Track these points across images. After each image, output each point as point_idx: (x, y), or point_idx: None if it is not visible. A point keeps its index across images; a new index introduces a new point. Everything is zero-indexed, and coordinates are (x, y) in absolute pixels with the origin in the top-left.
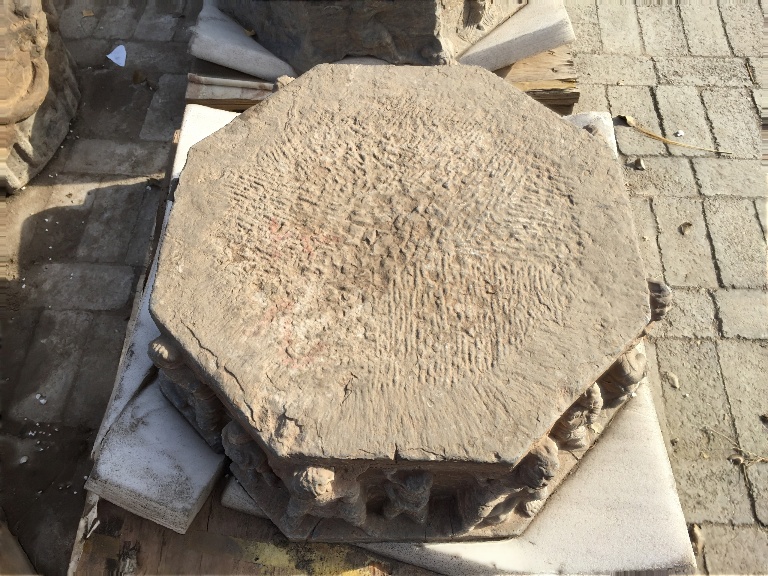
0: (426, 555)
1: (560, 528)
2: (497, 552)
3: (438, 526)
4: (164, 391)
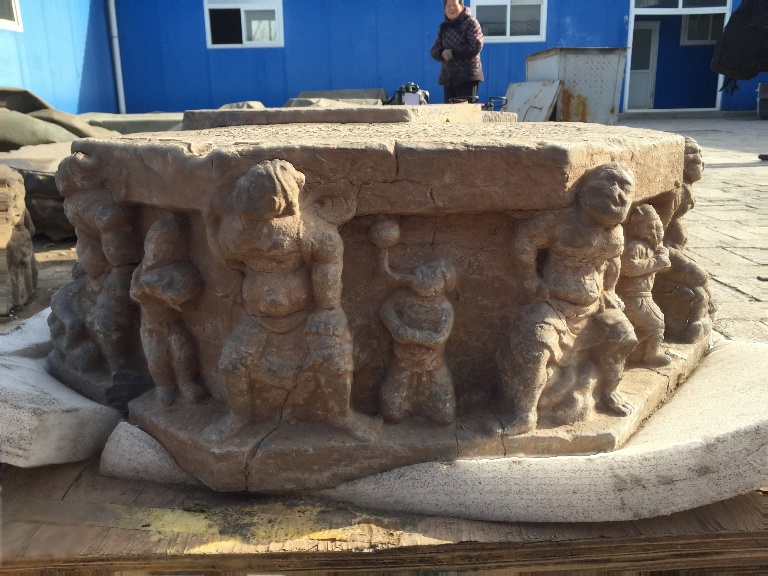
0: (463, 473)
1: (678, 422)
2: None
3: (476, 428)
4: (52, 328)
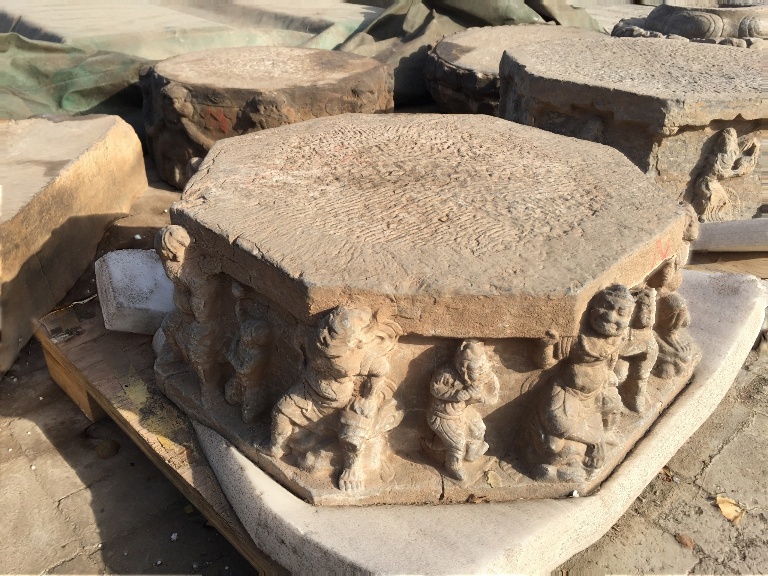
0: (225, 455)
1: (355, 517)
2: (279, 493)
3: (256, 435)
4: None
